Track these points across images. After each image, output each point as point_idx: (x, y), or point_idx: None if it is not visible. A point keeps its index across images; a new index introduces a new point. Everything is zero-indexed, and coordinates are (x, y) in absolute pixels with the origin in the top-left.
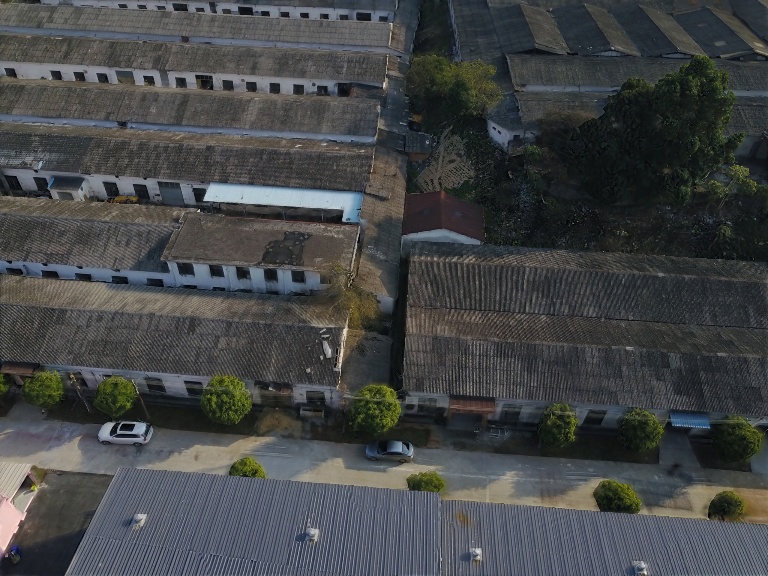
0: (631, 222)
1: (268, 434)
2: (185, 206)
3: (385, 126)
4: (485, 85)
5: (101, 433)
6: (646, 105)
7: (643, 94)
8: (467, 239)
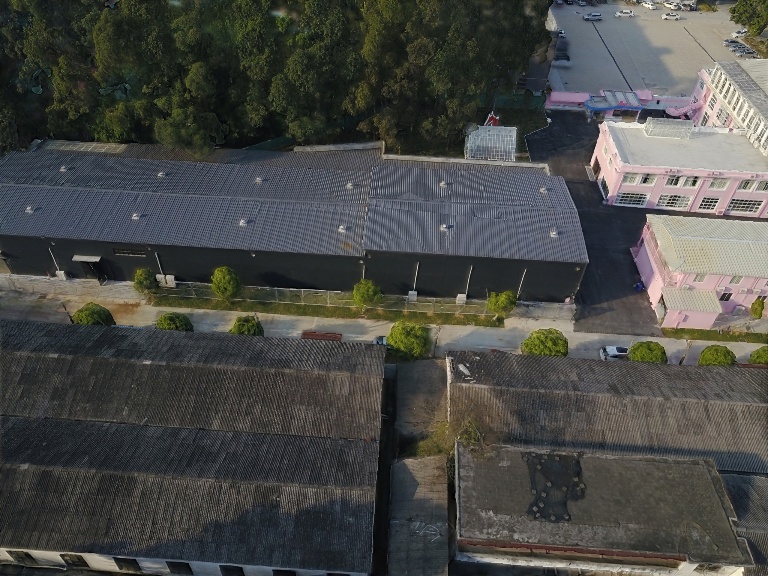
0: None
1: None
2: None
3: None
4: None
5: None
6: None
7: None
8: None
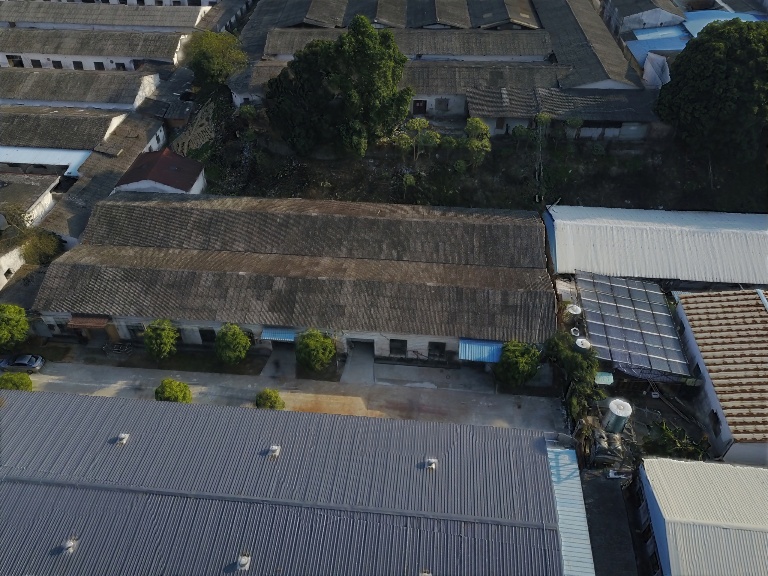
0: (336, 174)
1: None
2: None
3: (156, 96)
4: (235, 55)
5: None
6: (313, 62)
7: (314, 52)
8: (172, 189)
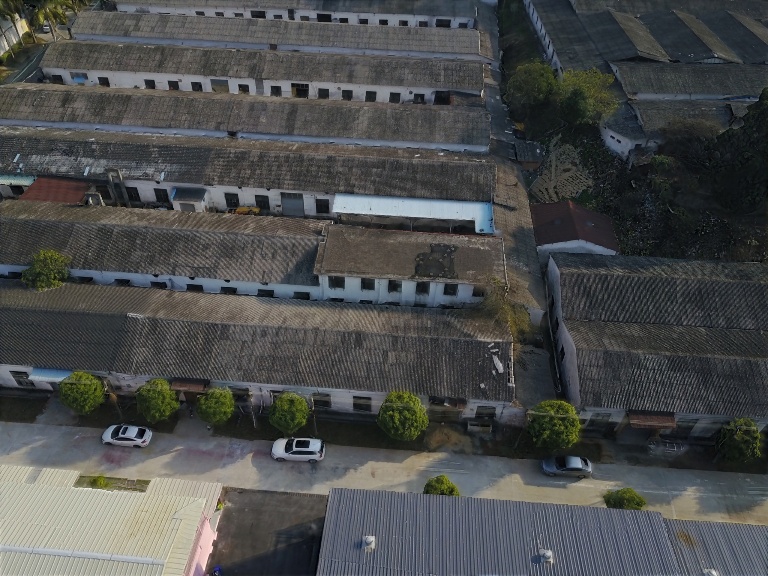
0: (761, 231)
1: (439, 450)
2: (305, 217)
3: (492, 135)
4: None
5: (275, 450)
6: None
7: None
8: (603, 250)
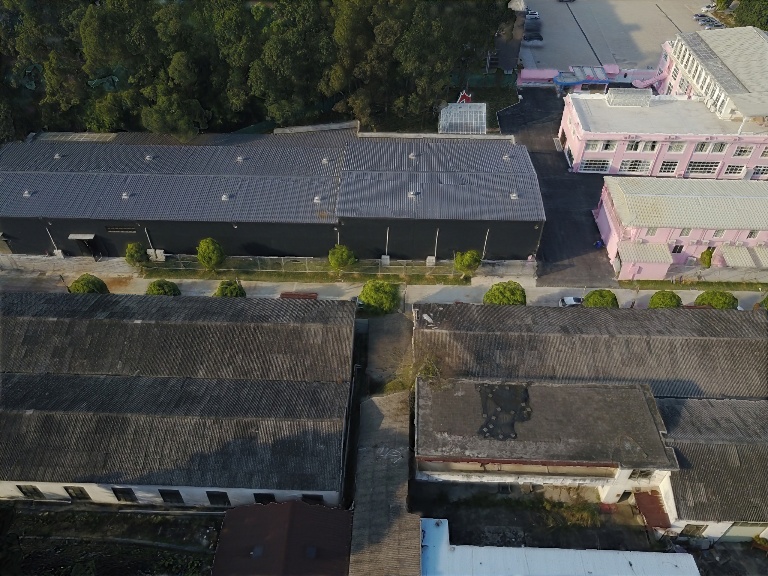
0: None
1: None
2: None
3: None
4: None
5: None
6: None
7: None
8: None
